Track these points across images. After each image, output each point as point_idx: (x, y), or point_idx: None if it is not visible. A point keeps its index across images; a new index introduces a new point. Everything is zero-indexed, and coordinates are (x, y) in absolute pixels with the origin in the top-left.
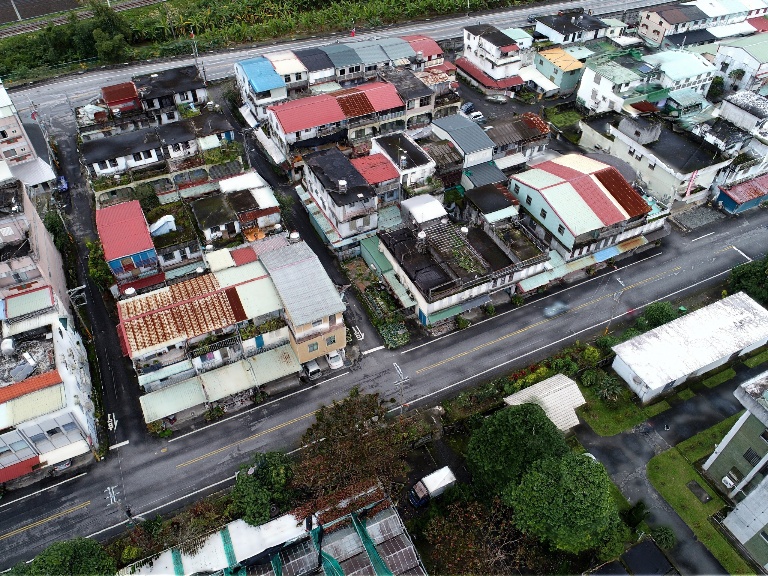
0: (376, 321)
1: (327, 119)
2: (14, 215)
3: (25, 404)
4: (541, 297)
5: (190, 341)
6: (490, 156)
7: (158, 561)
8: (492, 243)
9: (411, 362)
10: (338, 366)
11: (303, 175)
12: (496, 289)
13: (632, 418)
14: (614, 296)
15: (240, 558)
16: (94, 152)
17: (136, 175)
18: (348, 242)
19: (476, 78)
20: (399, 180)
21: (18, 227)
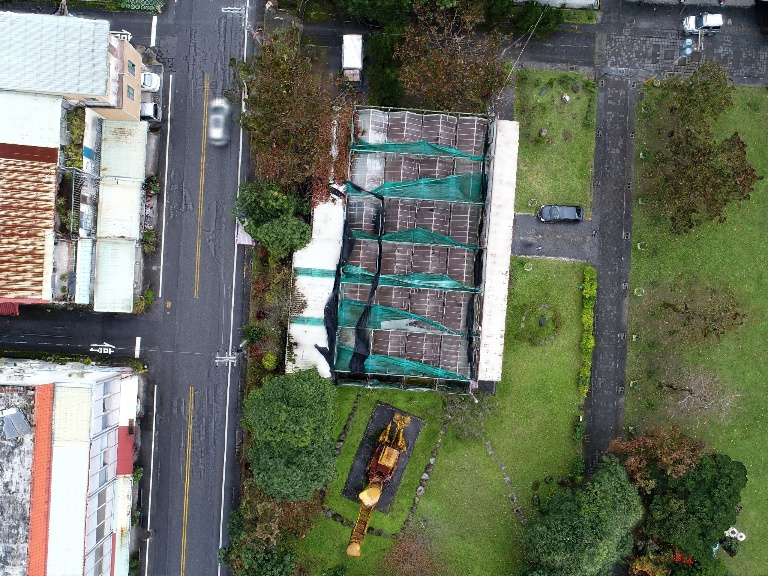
0: (111, 4)
1: None
2: None
3: (66, 427)
4: None
5: None
6: None
7: (295, 337)
8: None
9: None
10: (158, 82)
11: None
12: None
13: None
14: None
15: (332, 266)
16: None
17: None
18: None
19: None
20: None
21: None
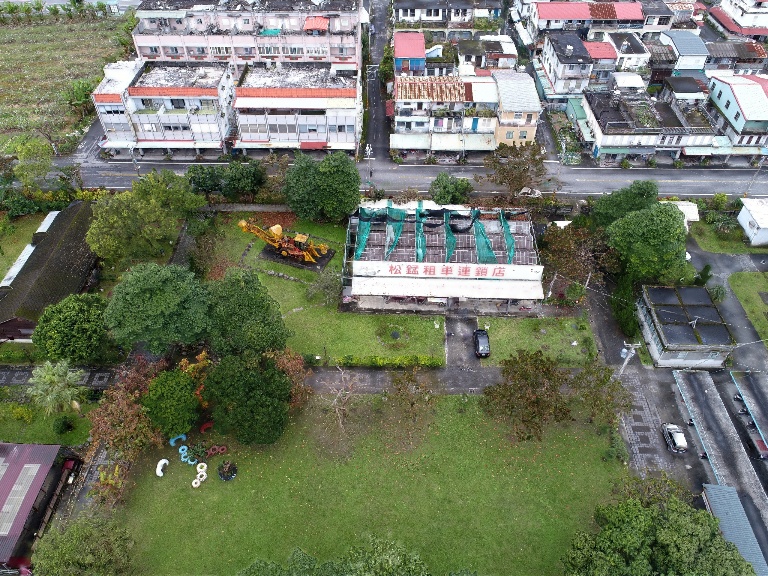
0: (560, 148)
1: (575, 16)
2: (353, 11)
3: (334, 101)
4: (700, 168)
5: (432, 106)
6: (702, 65)
7: (379, 201)
8: (673, 115)
9: (575, 174)
10: None
11: (542, 51)
12: (663, 146)
13: (736, 249)
14: (759, 162)
15: None
16: (402, 3)
17: (425, 24)
18: (559, 97)
19: (723, 24)
20: (616, 62)
21: (352, 21)
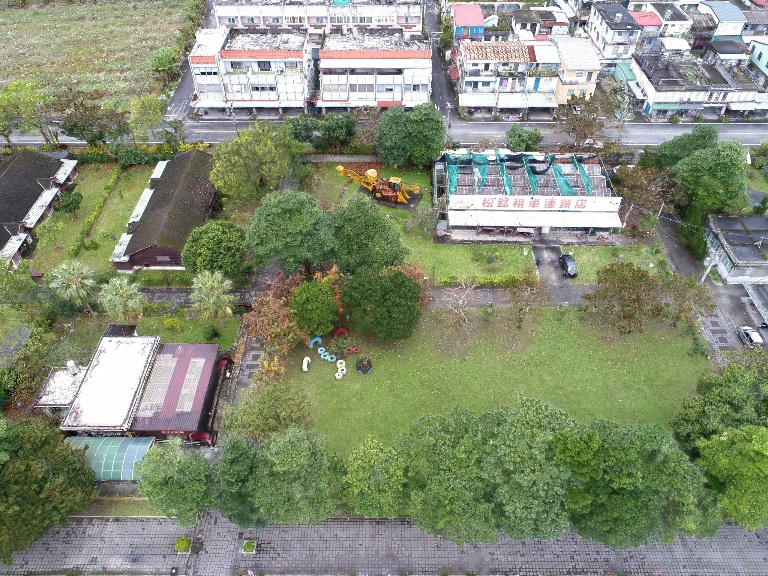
0: None
1: None
2: None
3: (411, 62)
4: (744, 122)
5: (498, 67)
6: (740, 31)
7: (459, 150)
8: (718, 74)
9: (630, 128)
10: None
11: (587, 21)
12: (710, 102)
13: None
14: None
15: None
16: None
17: None
18: (608, 62)
19: None
20: (660, 29)
21: None
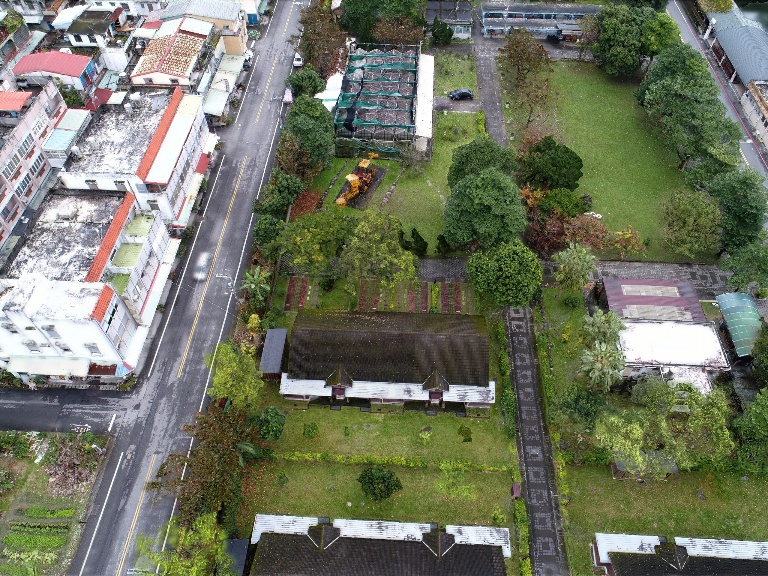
0: None
1: None
2: (6, 65)
3: (185, 109)
4: None
5: None
6: None
7: None
8: None
9: (275, 36)
10: (252, 54)
11: None
12: None
13: None
14: None
15: (336, 97)
16: None
17: None
18: None
19: None
20: None
21: (12, 77)
